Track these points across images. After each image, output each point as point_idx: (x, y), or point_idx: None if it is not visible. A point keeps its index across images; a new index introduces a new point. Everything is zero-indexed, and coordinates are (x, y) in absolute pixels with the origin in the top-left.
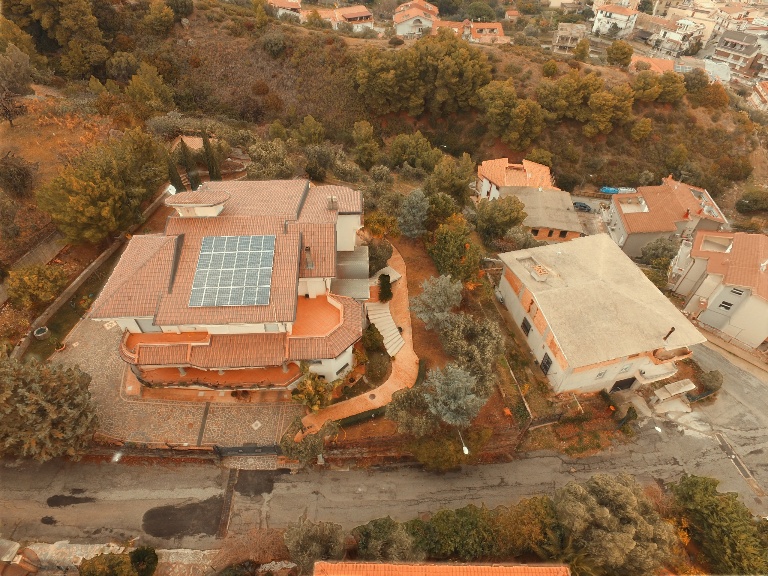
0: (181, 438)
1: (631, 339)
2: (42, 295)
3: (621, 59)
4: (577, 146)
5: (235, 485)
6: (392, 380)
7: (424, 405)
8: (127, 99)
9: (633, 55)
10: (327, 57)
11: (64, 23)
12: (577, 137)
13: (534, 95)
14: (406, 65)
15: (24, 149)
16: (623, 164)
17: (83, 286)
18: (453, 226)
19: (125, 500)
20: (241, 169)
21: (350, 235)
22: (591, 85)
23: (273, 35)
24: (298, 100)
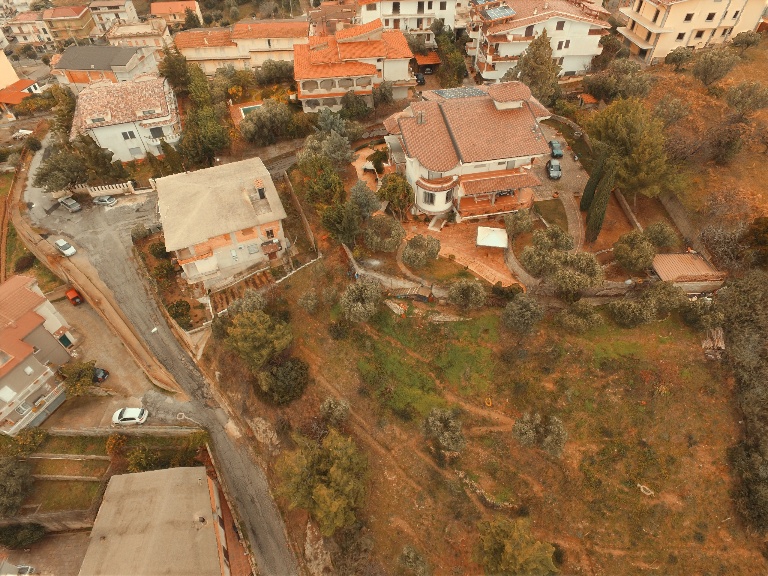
0: None
1: (211, 170)
2: None
3: None
4: None
5: None
6: None
7: None
8: None
9: None
10: None
11: None
12: None
13: None
14: None
15: None
16: None
17: None
18: None
19: None
20: None
21: None
22: None
23: None
24: None
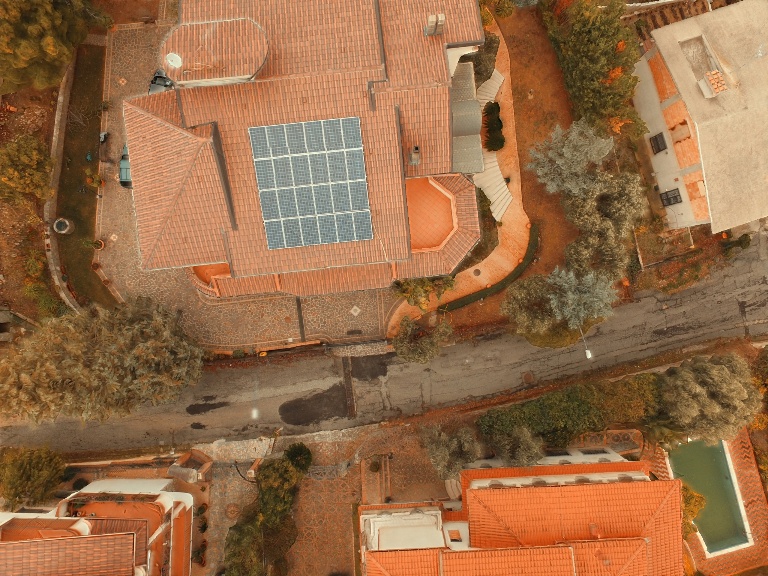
0: (283, 334)
1: None
2: (39, 195)
3: None
4: None
5: (351, 372)
6: (498, 251)
7: (542, 297)
8: None
9: None
10: None
11: None
12: None
13: None
14: None
15: None
16: None
17: (68, 140)
18: None
19: (256, 400)
20: None
21: (453, 62)
22: None
23: None
24: None
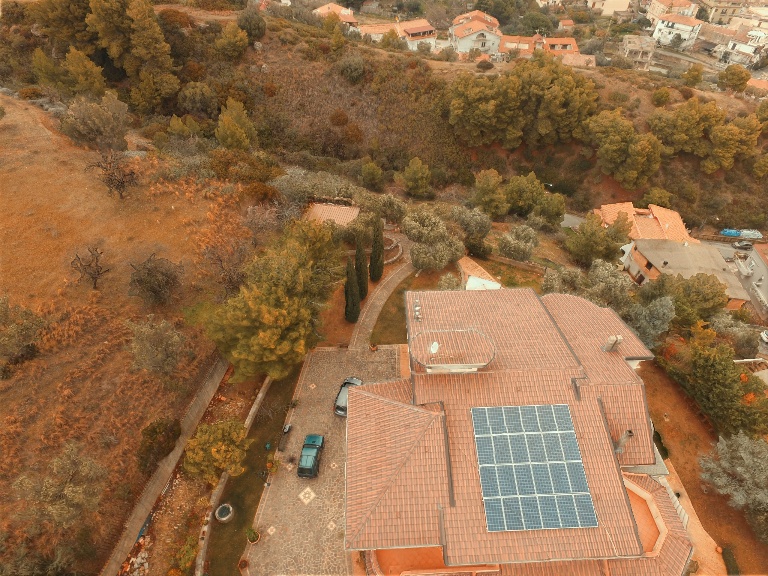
0: None
1: None
2: (232, 470)
3: (736, 85)
4: (693, 183)
5: None
6: None
7: None
8: (243, 156)
9: None
10: (410, 83)
11: (135, 52)
12: (693, 173)
13: (644, 126)
14: (505, 94)
15: (144, 230)
16: (745, 203)
17: (253, 429)
18: (698, 339)
19: None
20: (391, 246)
21: None
22: (712, 116)
23: (353, 59)
24: (380, 131)
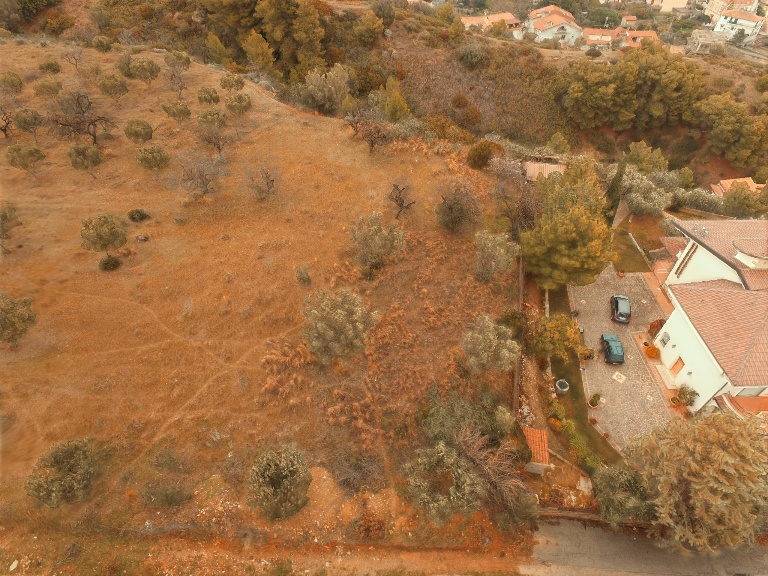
0: None
1: None
2: (579, 348)
3: None
4: None
5: None
6: None
7: None
8: None
9: (762, 62)
10: (524, 69)
11: (296, 36)
12: None
13: (750, 110)
14: (622, 78)
15: (403, 178)
16: None
17: None
18: None
19: None
20: None
21: None
22: None
23: (474, 46)
24: (496, 113)
